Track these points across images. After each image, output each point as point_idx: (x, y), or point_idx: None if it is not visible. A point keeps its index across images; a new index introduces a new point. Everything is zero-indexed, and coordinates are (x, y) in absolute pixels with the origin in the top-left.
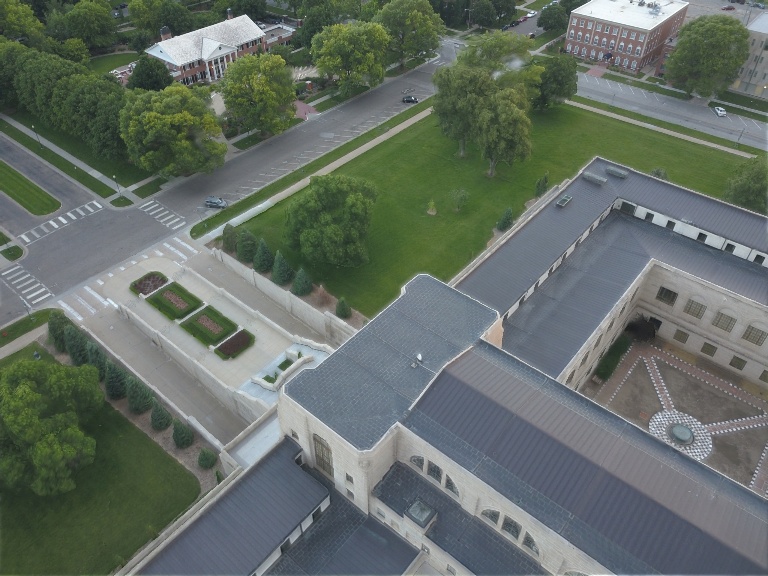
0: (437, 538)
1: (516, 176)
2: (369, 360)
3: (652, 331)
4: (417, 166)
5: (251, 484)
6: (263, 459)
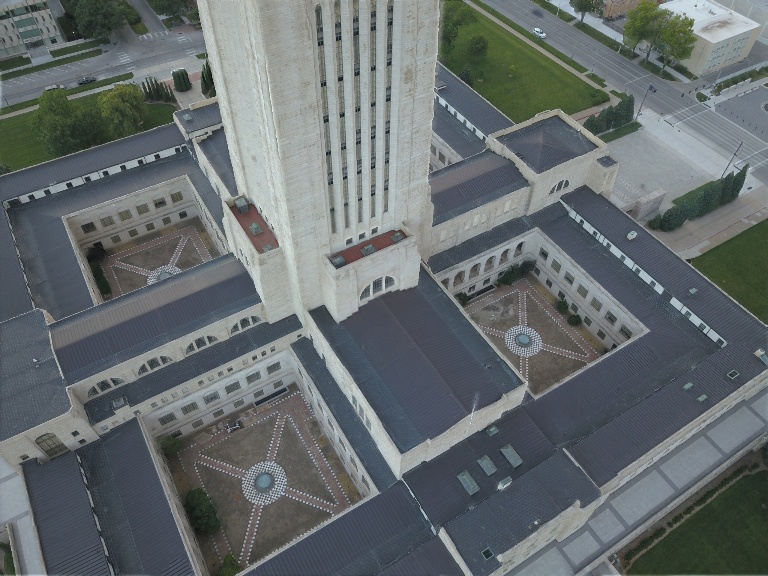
0: (136, 402)
1: None
2: (14, 389)
3: (102, 250)
4: None
5: (37, 493)
6: (26, 482)
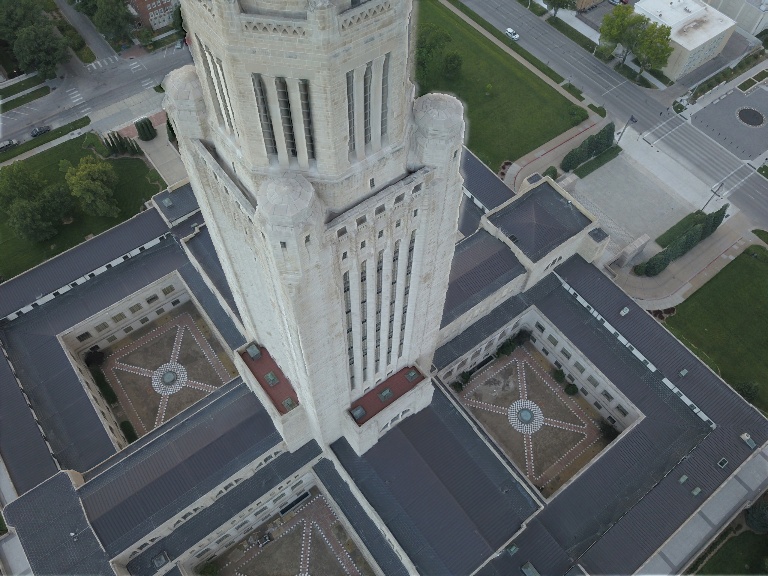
0: (176, 555)
1: None
2: (58, 568)
3: (100, 355)
4: None
5: None
6: None
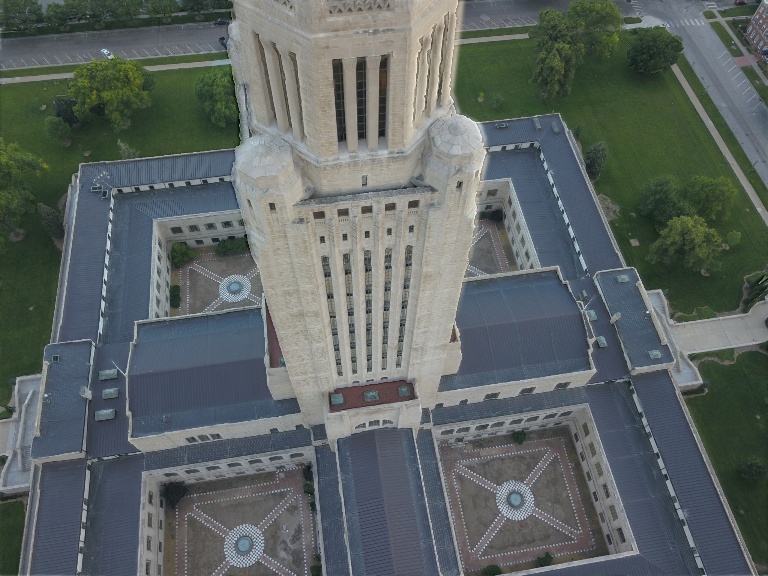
0: None
1: (556, 105)
2: None
3: (496, 217)
4: (508, 67)
5: None
6: None
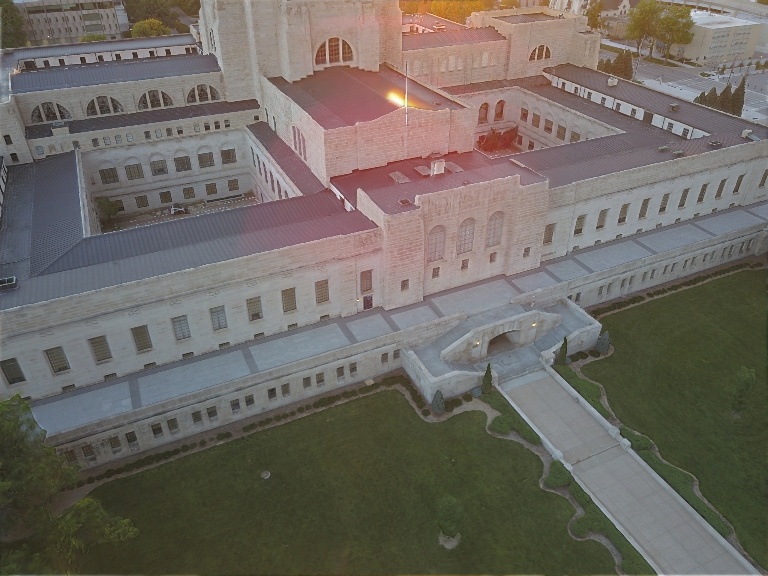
0: None
1: None
2: None
3: None
4: None
5: None
6: None
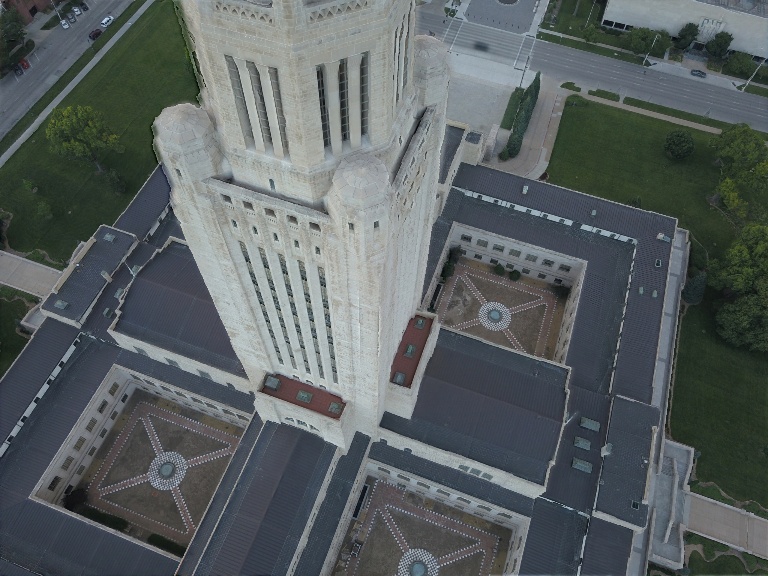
0: None
1: None
2: None
3: (80, 492)
4: None
5: None
6: None
